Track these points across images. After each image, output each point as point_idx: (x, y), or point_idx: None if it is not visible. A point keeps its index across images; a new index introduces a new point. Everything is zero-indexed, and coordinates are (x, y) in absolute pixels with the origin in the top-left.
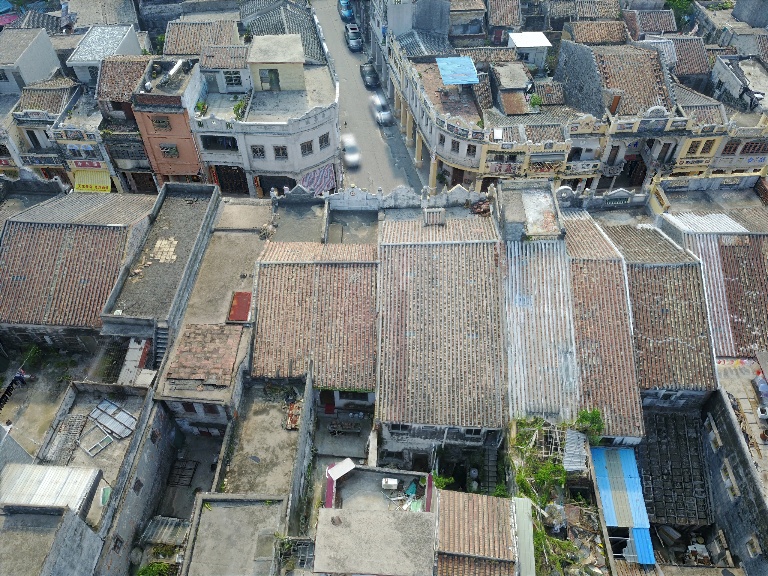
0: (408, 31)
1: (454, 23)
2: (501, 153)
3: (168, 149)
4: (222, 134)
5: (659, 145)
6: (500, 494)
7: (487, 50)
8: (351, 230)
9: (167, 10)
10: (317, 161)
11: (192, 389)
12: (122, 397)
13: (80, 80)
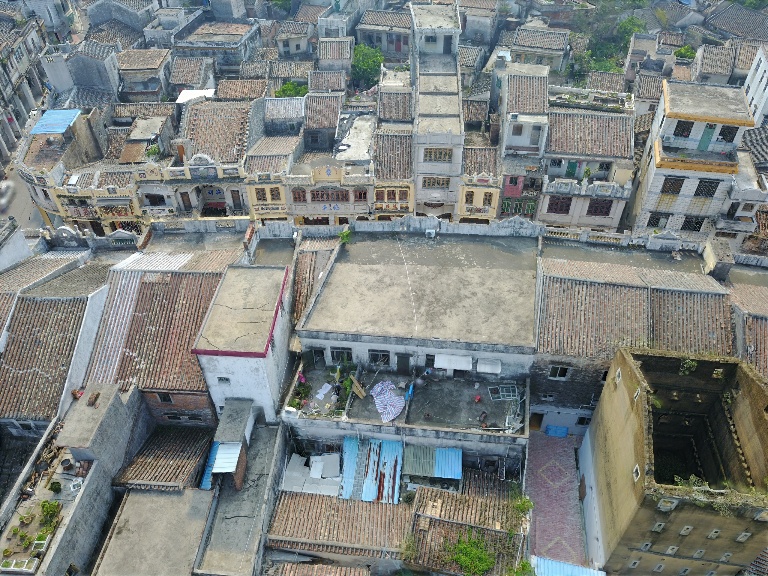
0: (70, 87)
1: (132, 81)
2: (69, 197)
3: None
4: None
5: (226, 192)
6: None
7: (148, 105)
8: None
9: None
10: None
11: None
12: None
13: None
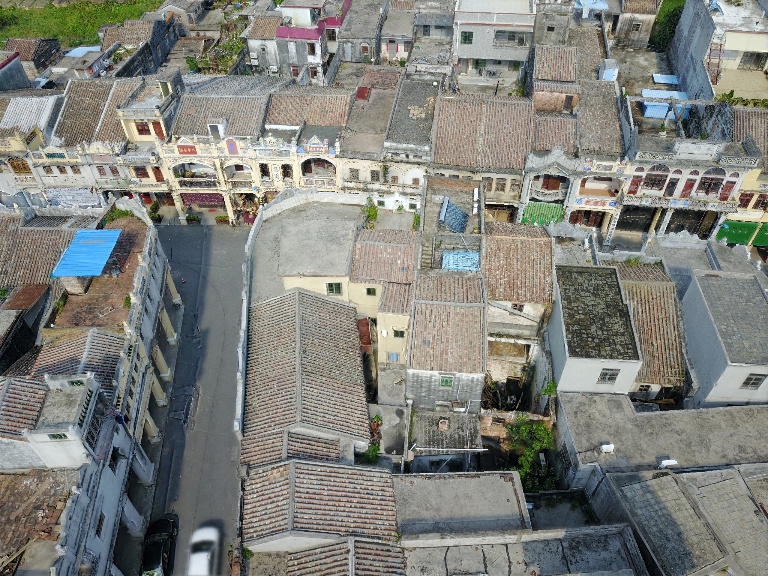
0: None
1: None
2: None
3: None
4: None
5: None
6: (246, 71)
7: None
8: None
9: (566, 534)
10: None
11: None
12: None
13: None
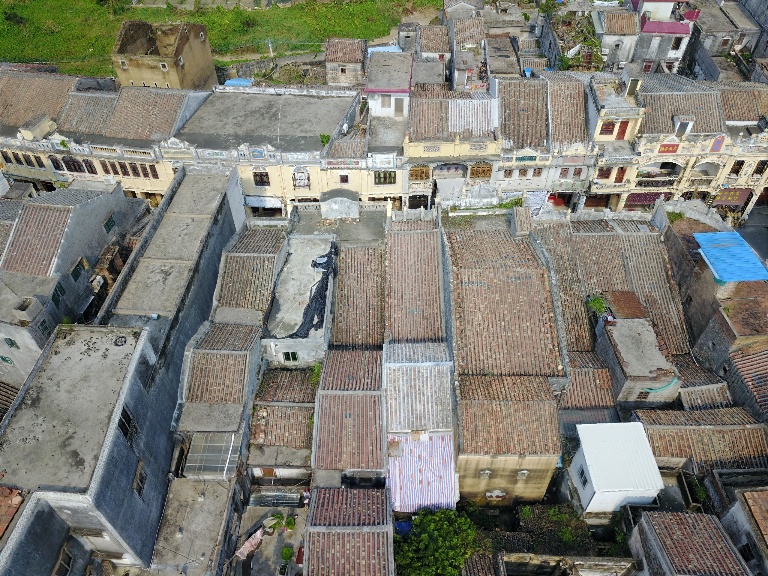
0: None
1: None
2: None
3: None
4: None
5: None
6: None
7: None
8: None
9: None
10: None
11: None
12: None
13: None
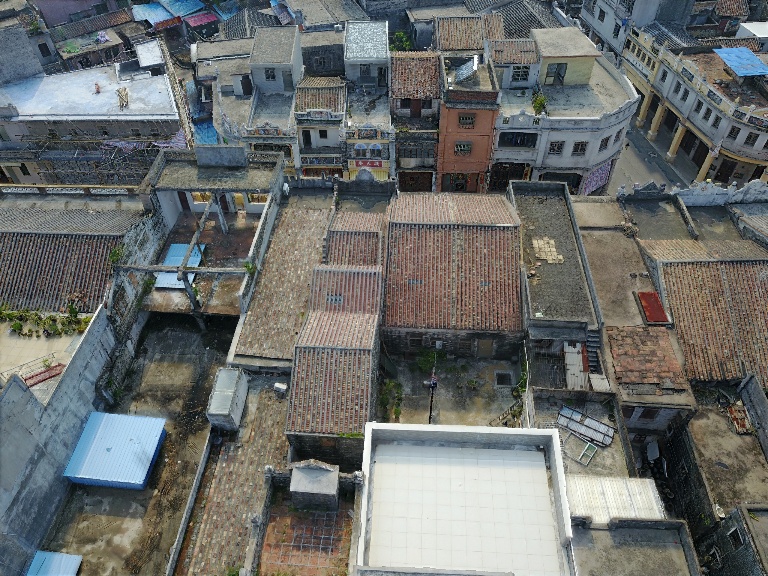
0: (650, 23)
1: None
2: None
3: (463, 147)
4: (526, 130)
5: None
6: None
7: (728, 41)
8: (705, 226)
9: (392, 6)
10: (606, 157)
11: (651, 394)
12: (581, 403)
13: (348, 78)
